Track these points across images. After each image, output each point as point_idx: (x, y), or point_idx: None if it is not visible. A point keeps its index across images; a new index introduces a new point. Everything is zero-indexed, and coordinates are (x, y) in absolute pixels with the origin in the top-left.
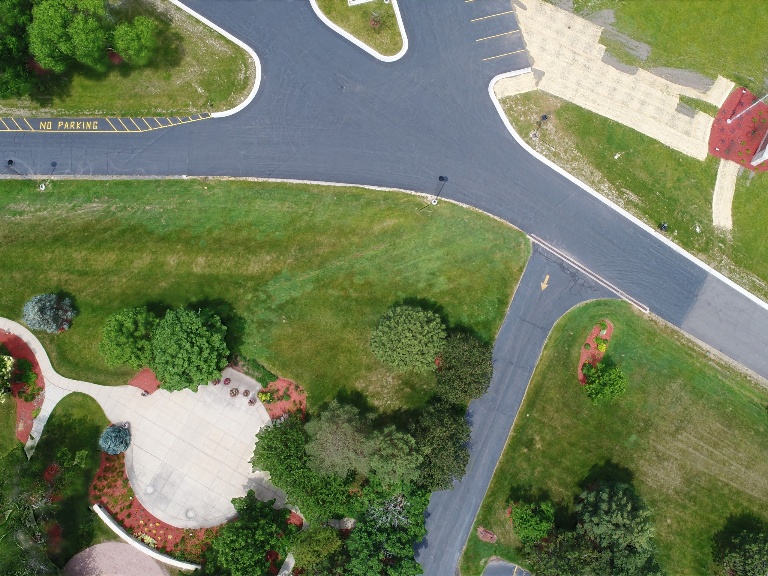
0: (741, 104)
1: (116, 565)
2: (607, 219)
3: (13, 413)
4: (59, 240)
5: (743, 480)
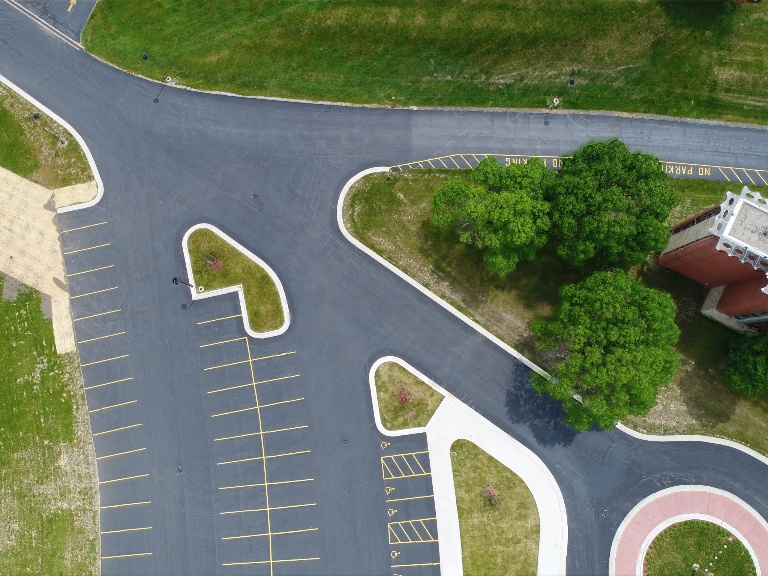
0: None
1: None
2: (5, 63)
3: None
4: (531, 41)
5: None
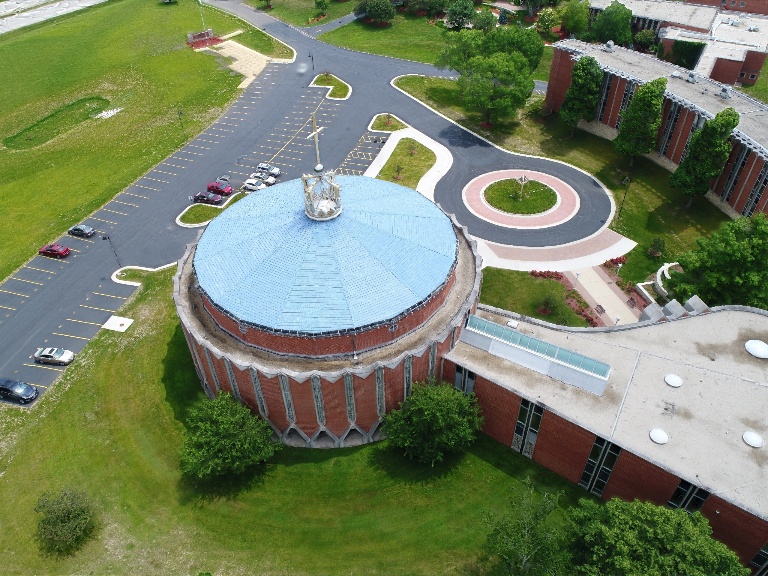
0: (198, 46)
1: (512, 7)
2: None
3: None
4: None
5: (295, 1)
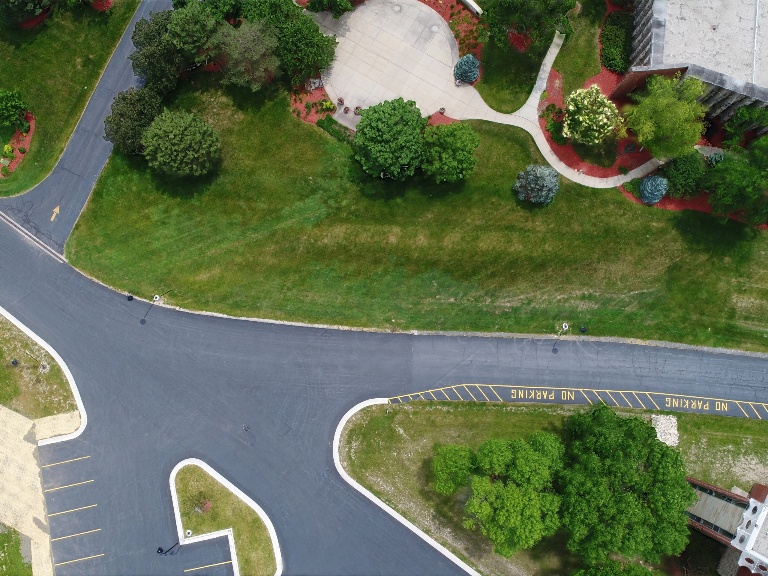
0: None
1: None
2: None
3: (566, 95)
4: (539, 265)
5: None
